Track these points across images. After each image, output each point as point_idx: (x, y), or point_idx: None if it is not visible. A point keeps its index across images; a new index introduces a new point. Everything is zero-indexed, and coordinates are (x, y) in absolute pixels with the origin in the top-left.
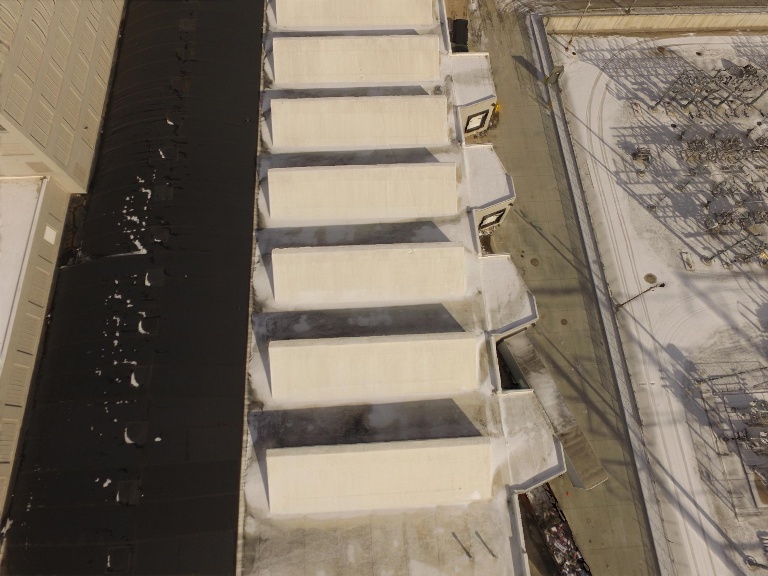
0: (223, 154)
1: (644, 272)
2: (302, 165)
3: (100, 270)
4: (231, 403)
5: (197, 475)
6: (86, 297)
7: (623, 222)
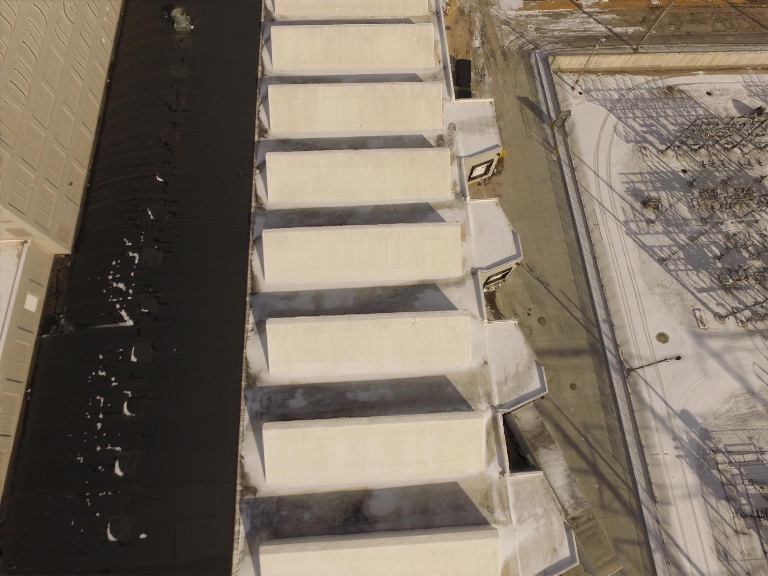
0: (215, 212)
1: (656, 331)
2: (299, 222)
3: (84, 342)
4: (222, 490)
5: (185, 575)
6: (68, 373)
7: (633, 276)
